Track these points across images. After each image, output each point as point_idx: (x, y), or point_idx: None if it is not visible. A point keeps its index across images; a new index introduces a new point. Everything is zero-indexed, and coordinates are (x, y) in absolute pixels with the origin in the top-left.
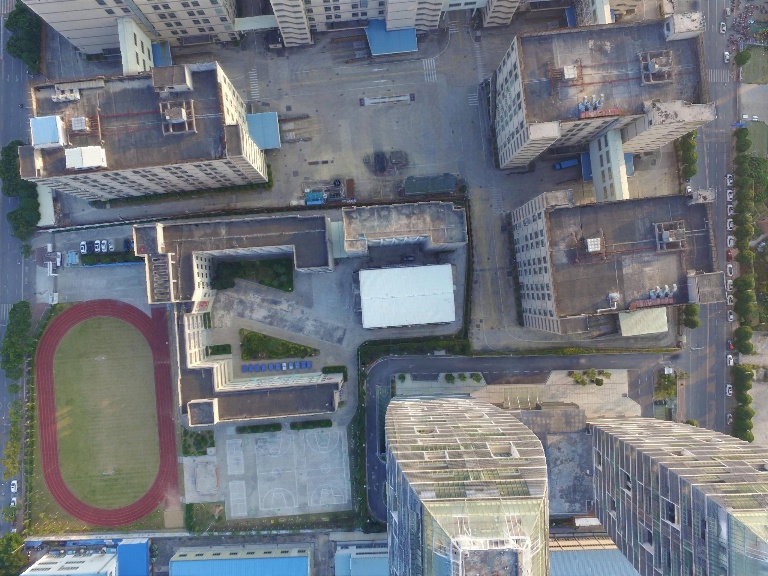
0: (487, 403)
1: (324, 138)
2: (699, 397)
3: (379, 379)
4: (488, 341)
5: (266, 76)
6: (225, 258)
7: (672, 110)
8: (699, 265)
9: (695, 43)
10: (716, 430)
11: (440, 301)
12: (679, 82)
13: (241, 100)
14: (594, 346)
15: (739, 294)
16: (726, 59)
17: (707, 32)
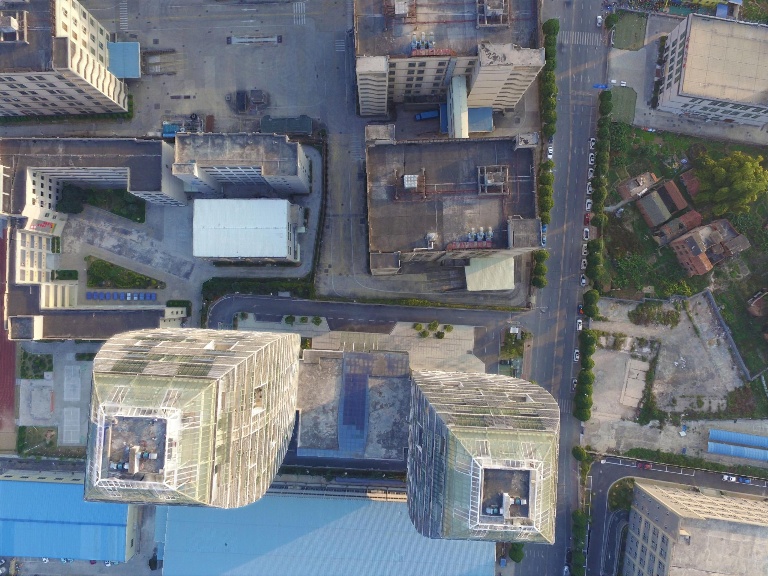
0: None
1: (188, 73)
2: (546, 360)
3: (222, 316)
4: (335, 287)
5: (136, 8)
6: (79, 184)
7: (501, 52)
8: (521, 212)
9: None
10: (561, 395)
11: (272, 235)
12: (516, 27)
13: (100, 26)
14: (442, 300)
15: (589, 257)
16: (598, 23)
17: None
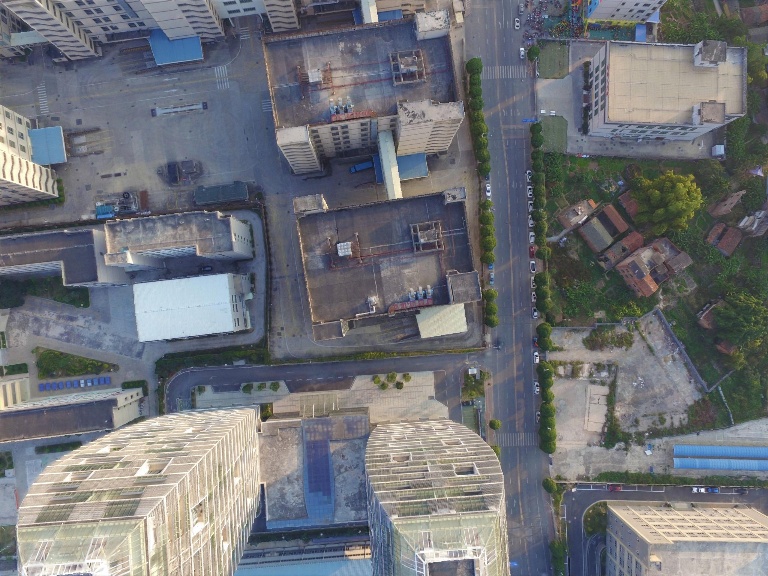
0: (244, 414)
1: (116, 150)
2: (507, 396)
3: (179, 392)
4: (290, 349)
5: (55, 90)
6: (17, 276)
7: (419, 110)
8: (459, 265)
9: (447, 41)
10: (526, 429)
11: (216, 311)
12: (433, 81)
13: (18, 116)
14: (398, 349)
15: (537, 291)
16: (521, 55)
17: (502, 29)
